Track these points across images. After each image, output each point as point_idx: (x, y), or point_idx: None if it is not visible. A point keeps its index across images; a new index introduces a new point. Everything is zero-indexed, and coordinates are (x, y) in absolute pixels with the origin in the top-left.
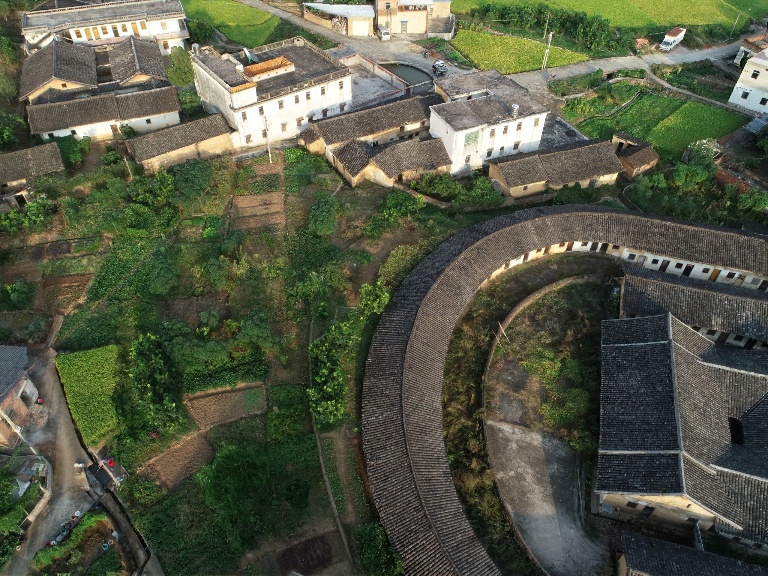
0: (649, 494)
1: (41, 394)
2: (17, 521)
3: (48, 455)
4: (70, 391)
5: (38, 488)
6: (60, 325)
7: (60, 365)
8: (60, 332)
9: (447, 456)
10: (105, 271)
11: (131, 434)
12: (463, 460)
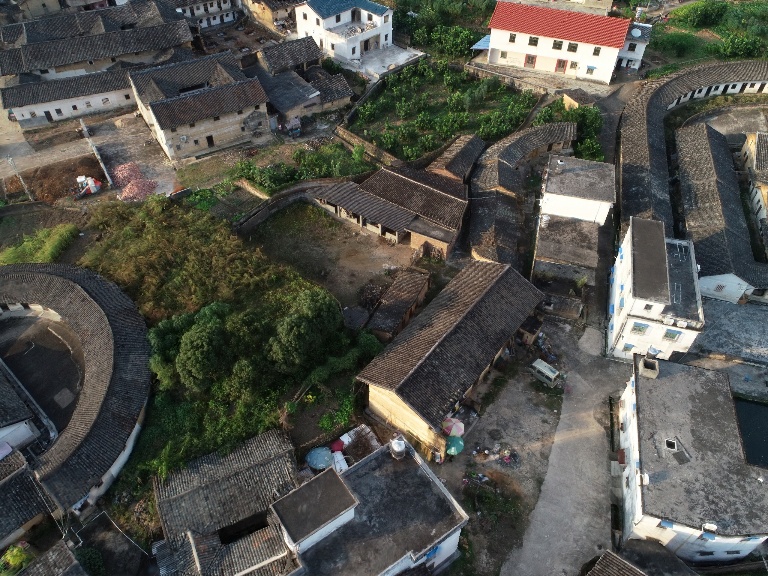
0: None
1: (683, 2)
2: (635, 3)
3: (661, 8)
4: (689, 5)
5: (648, 3)
6: (718, 0)
7: (699, 1)
8: (715, 1)
9: None
10: (758, 5)
11: (681, 21)
12: None
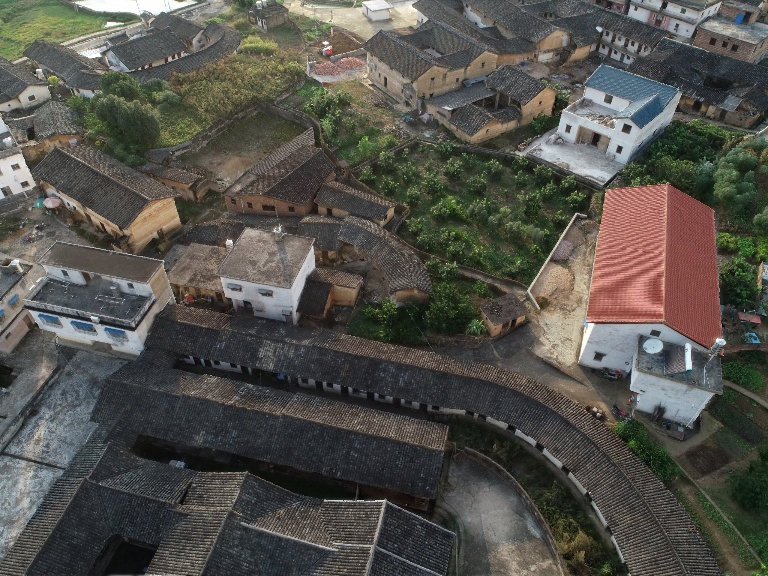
0: (412, 513)
1: None
2: None
3: None
4: None
5: None
6: None
7: None
8: None
9: (611, 571)
10: None
11: None
12: (592, 569)
